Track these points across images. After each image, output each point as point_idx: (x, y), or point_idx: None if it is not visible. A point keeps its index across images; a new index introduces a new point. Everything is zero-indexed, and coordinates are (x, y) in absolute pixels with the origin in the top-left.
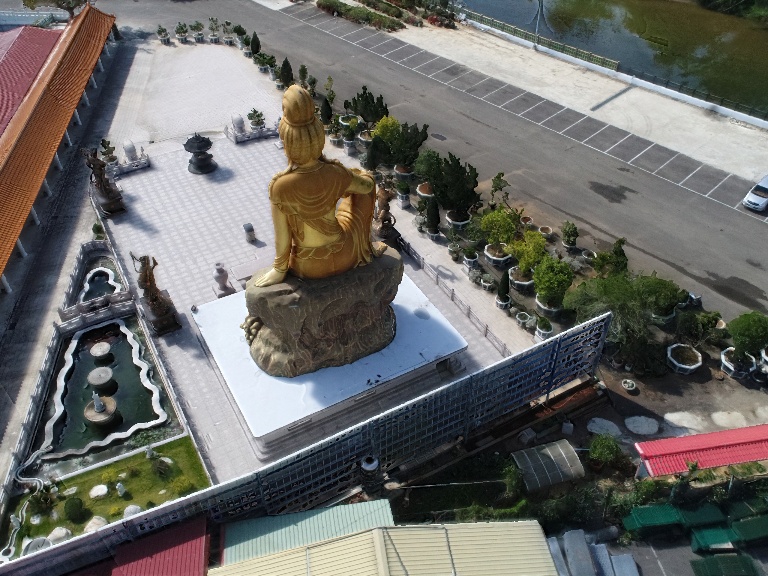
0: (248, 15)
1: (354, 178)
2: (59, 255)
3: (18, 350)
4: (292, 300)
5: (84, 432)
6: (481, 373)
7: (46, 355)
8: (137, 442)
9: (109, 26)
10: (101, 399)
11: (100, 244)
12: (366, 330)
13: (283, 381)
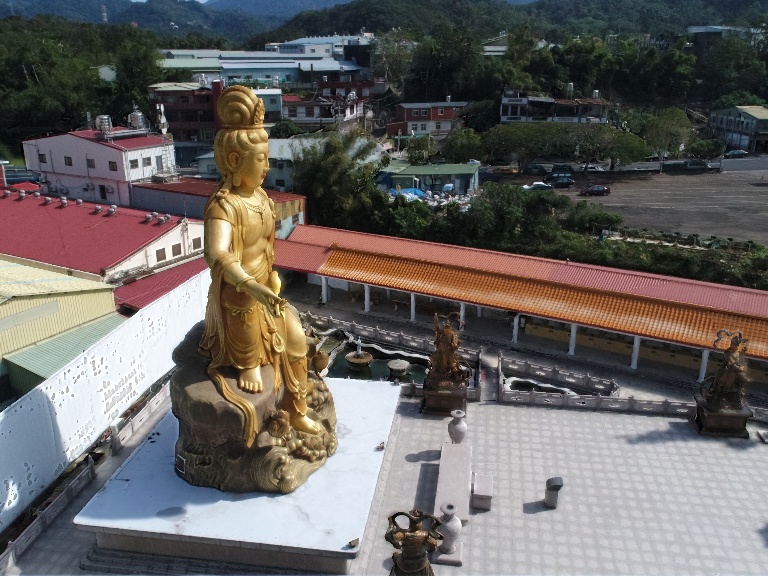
0: None
1: None
2: (621, 382)
3: (479, 348)
4: None
5: None
6: (3, 421)
7: None
8: (313, 370)
9: None
10: (369, 358)
11: (616, 396)
12: None
13: None
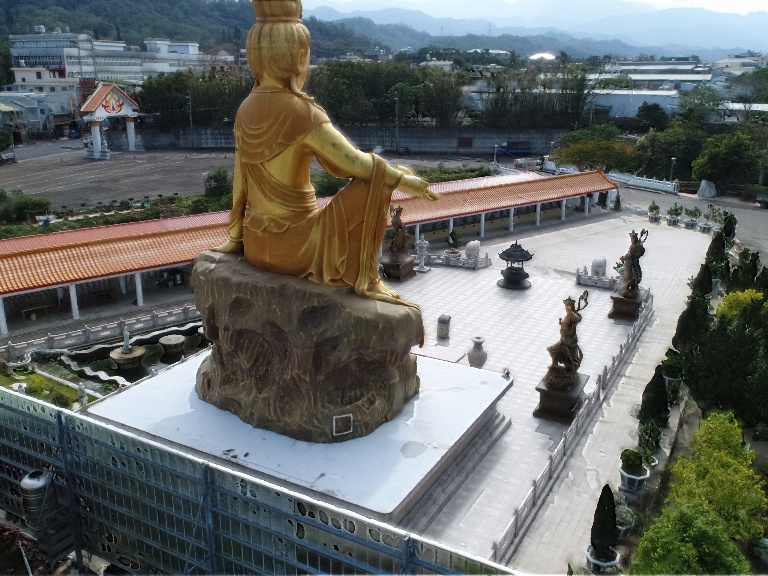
0: None
1: (321, 129)
2: None
3: None
4: (205, 269)
5: (112, 369)
6: (231, 479)
7: (177, 309)
8: (100, 387)
9: (600, 188)
10: (140, 348)
11: None
12: (289, 389)
13: (191, 396)
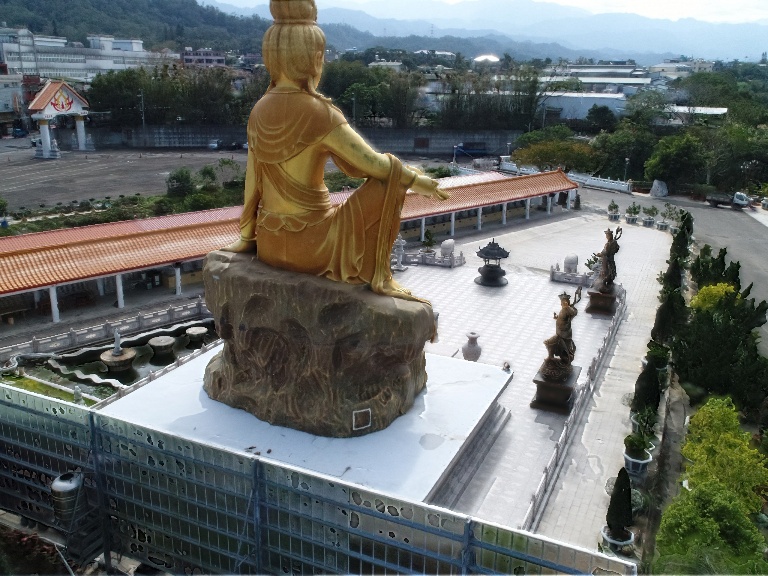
0: (731, 224)
1: (340, 130)
2: None
3: None
4: (219, 268)
5: (101, 372)
6: (281, 473)
7: (162, 311)
8: (94, 390)
9: (562, 188)
10: (130, 350)
11: None
12: (307, 385)
13: (201, 396)
